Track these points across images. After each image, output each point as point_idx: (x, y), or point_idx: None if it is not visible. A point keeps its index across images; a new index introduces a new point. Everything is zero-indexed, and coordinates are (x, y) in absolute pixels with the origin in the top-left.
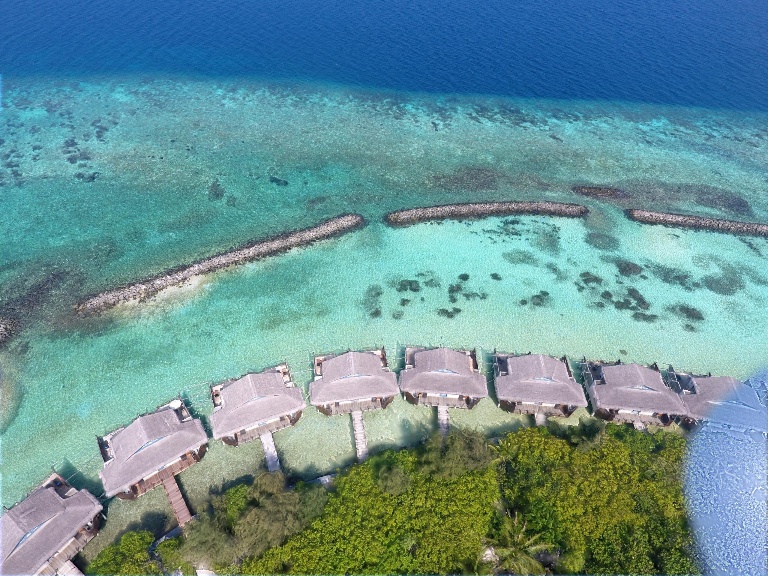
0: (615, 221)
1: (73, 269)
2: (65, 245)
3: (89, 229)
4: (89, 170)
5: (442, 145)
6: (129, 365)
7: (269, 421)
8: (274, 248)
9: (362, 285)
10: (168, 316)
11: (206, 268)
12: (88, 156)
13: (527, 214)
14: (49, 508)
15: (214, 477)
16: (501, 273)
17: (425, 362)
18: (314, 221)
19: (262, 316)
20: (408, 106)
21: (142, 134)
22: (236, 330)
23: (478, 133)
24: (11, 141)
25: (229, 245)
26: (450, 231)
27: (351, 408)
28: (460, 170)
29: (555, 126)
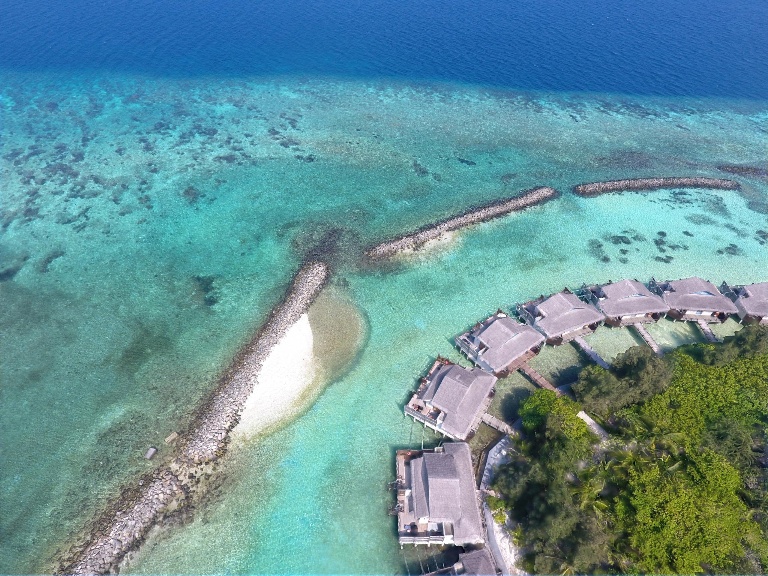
0: (765, 193)
1: (344, 227)
2: (324, 210)
3: (335, 198)
4: (304, 153)
5: (588, 133)
6: (434, 294)
7: (576, 329)
8: (498, 212)
9: (583, 239)
10: (442, 261)
11: (452, 226)
12: (296, 142)
13: (689, 187)
14: (468, 375)
15: (549, 367)
16: (691, 231)
17: (683, 287)
18: (515, 192)
19: (516, 261)
20: (541, 102)
21: (329, 124)
22: (501, 271)
23: (614, 124)
24: (223, 130)
25: (457, 210)
26: (632, 200)
27: (632, 321)
28: (615, 153)
29: (677, 118)
